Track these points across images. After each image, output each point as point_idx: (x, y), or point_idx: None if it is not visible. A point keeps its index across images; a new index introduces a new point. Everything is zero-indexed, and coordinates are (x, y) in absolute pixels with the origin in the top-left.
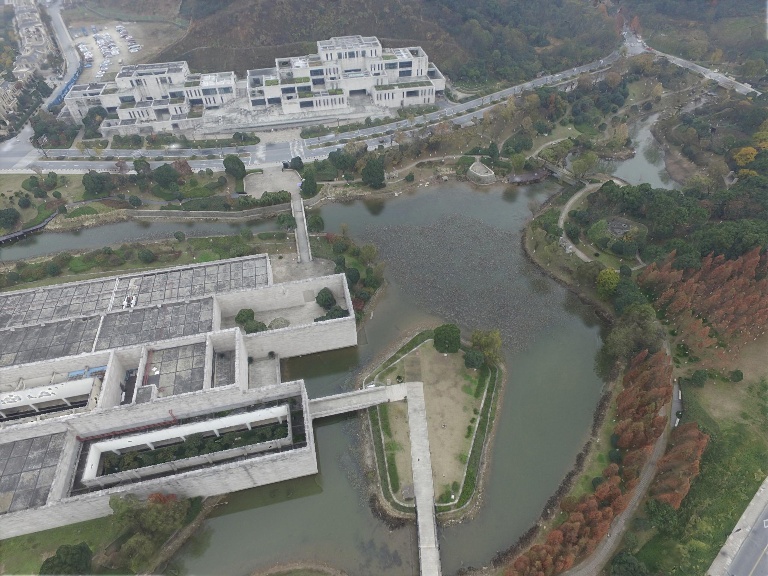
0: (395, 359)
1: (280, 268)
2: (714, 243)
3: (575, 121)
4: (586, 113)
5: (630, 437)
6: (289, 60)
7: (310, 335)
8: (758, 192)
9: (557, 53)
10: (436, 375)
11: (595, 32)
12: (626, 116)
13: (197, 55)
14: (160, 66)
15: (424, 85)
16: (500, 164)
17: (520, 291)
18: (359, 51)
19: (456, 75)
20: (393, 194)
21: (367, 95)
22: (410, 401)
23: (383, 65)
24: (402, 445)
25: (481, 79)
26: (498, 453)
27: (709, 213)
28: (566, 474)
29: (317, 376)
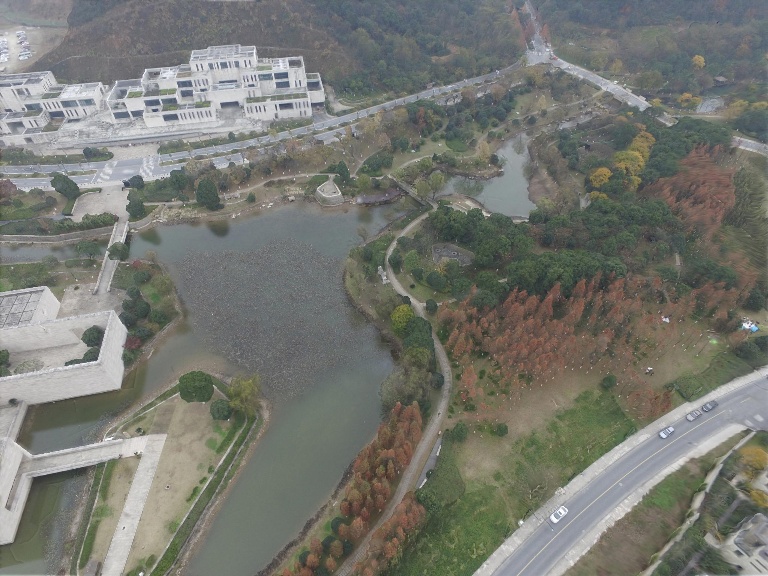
0: (150, 407)
1: (71, 300)
2: (521, 277)
3: (446, 137)
4: (462, 128)
5: (344, 506)
6: (160, 70)
7: (53, 381)
8: (597, 218)
9: (452, 63)
10: (185, 426)
11: (499, 41)
12: (506, 131)
13: (72, 64)
14: (21, 76)
15: (298, 97)
16: (352, 183)
17: (320, 327)
18: (232, 61)
19: (339, 86)
20: (230, 216)
21: (240, 107)
22: (144, 457)
23: (256, 76)
24: (113, 510)
25: (364, 91)
26: (224, 518)
27: (535, 242)
28: (286, 544)
29: (62, 426)
